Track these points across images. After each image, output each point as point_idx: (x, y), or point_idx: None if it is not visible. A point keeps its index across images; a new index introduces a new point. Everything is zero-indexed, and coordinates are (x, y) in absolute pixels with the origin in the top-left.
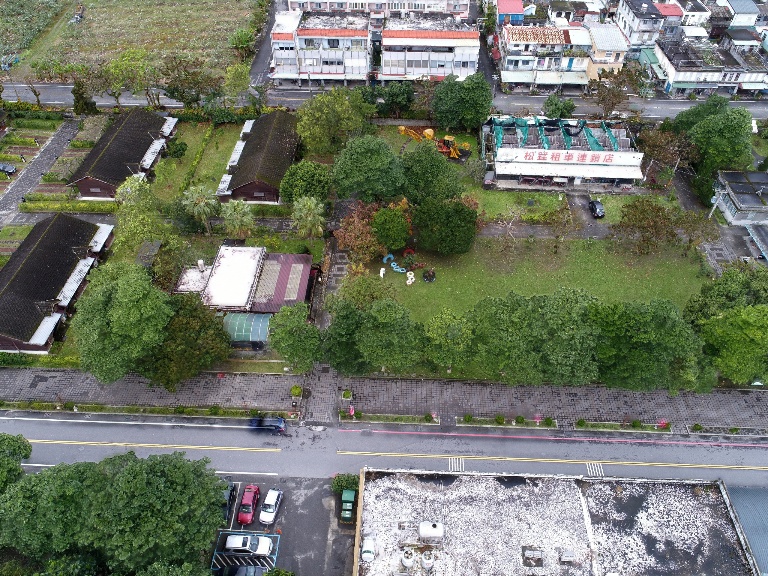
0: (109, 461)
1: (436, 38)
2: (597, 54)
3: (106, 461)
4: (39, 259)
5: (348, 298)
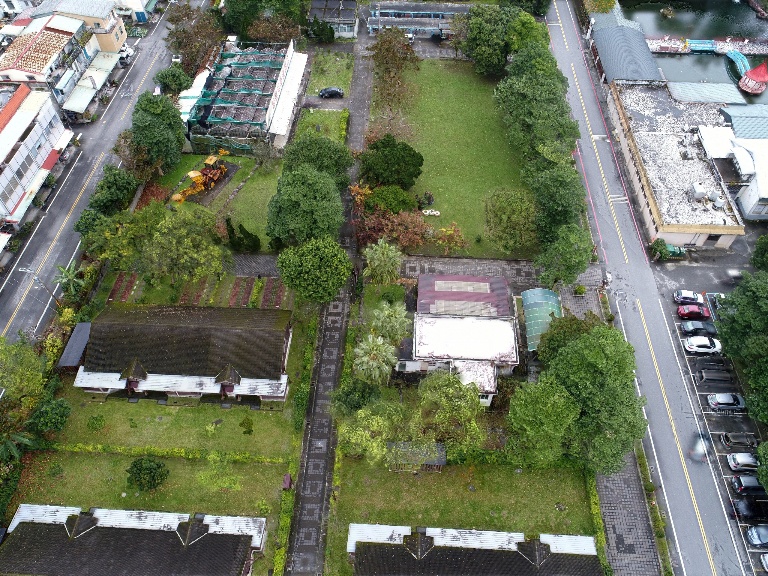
0: None
1: (5, 125)
2: (104, 24)
3: None
4: None
5: (526, 214)
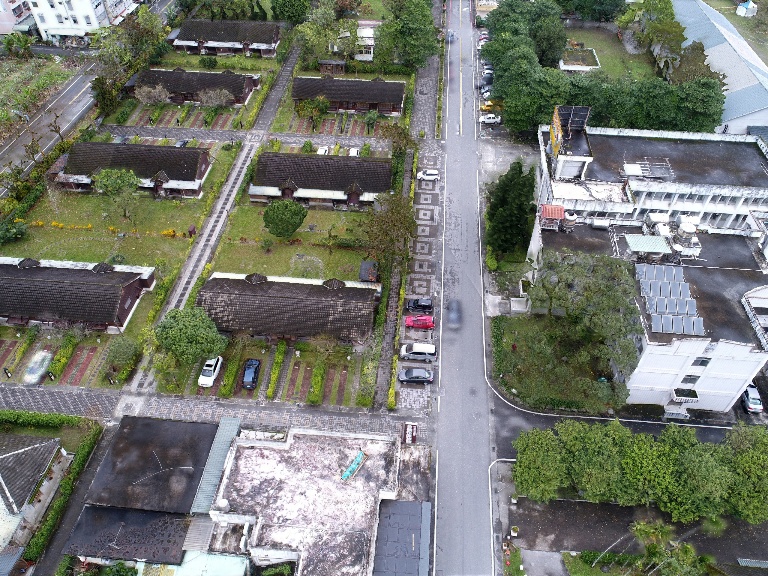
0: (502, 8)
1: None
2: None
3: None
4: None
5: None
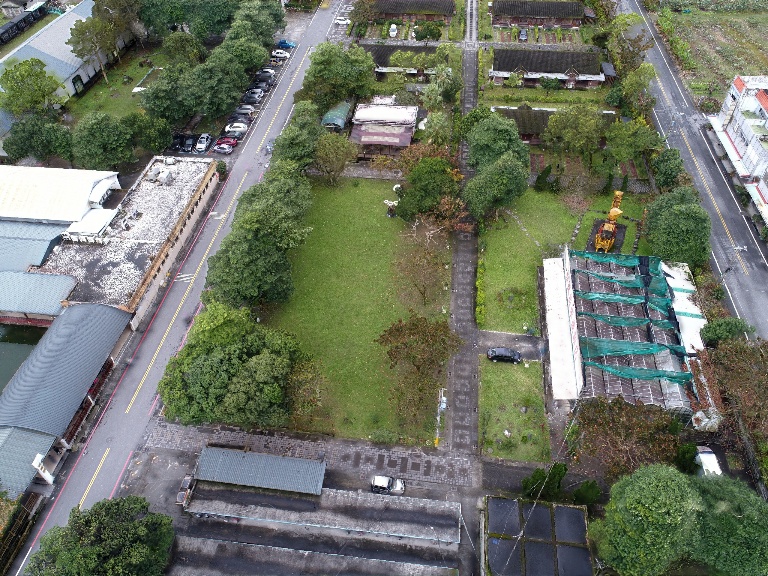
0: (223, 63)
1: None
2: None
3: (224, 63)
4: (406, 51)
5: None
